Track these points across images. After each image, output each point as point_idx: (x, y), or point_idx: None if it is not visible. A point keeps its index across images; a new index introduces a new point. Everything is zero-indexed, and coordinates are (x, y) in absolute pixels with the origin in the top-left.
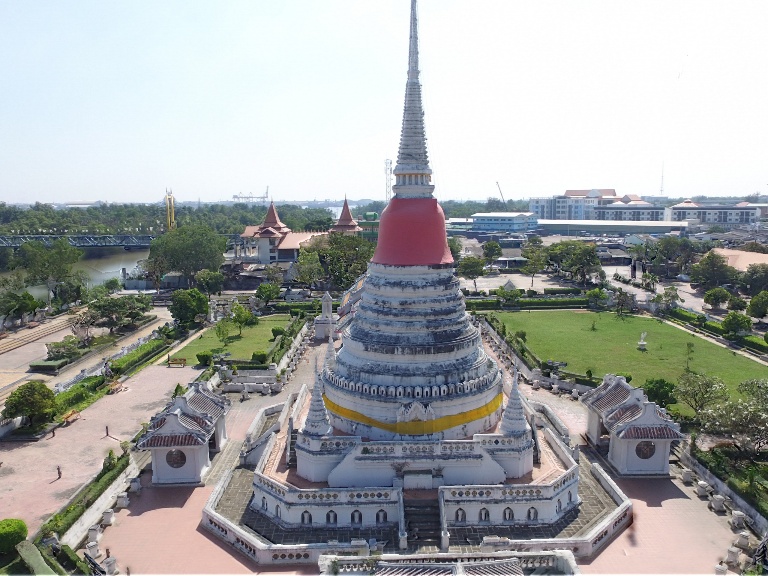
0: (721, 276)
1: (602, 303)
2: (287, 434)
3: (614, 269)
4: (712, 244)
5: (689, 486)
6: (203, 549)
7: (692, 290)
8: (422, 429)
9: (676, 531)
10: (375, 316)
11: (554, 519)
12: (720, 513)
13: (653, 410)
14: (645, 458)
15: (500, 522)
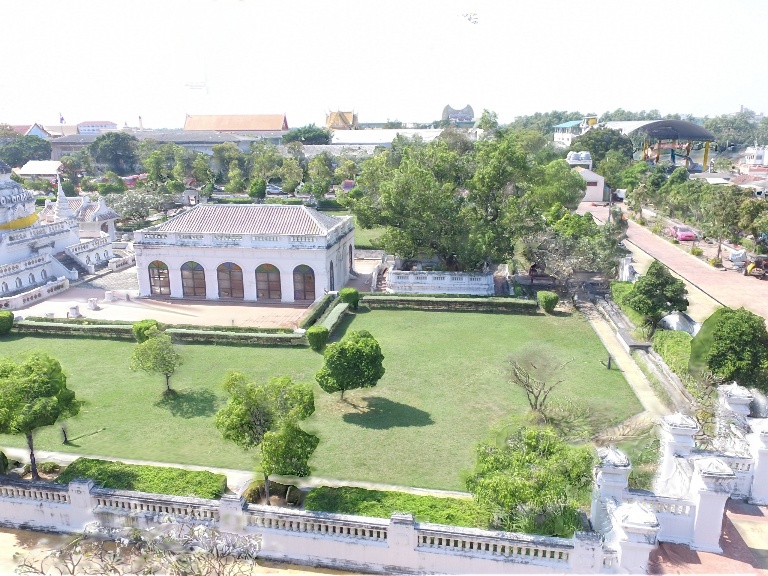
0: None
1: None
2: None
3: None
4: None
5: (131, 241)
6: None
7: None
8: (25, 223)
9: None
10: None
11: (114, 255)
12: None
13: (104, 203)
14: None
15: (96, 262)
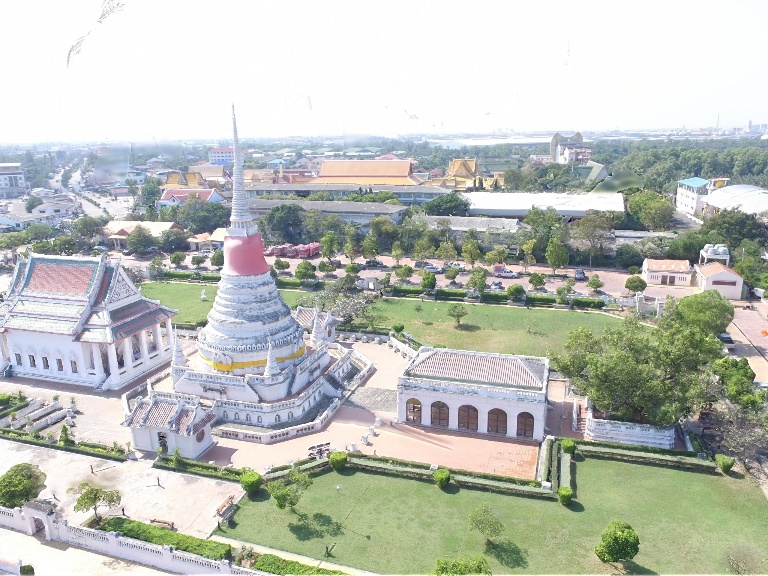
0: (152, 243)
1: None
2: (244, 388)
3: (17, 251)
4: (106, 218)
5: None
6: (292, 443)
7: (128, 257)
8: None
9: (372, 352)
10: (258, 305)
11: None
12: (368, 342)
13: None
14: (330, 337)
15: (343, 375)
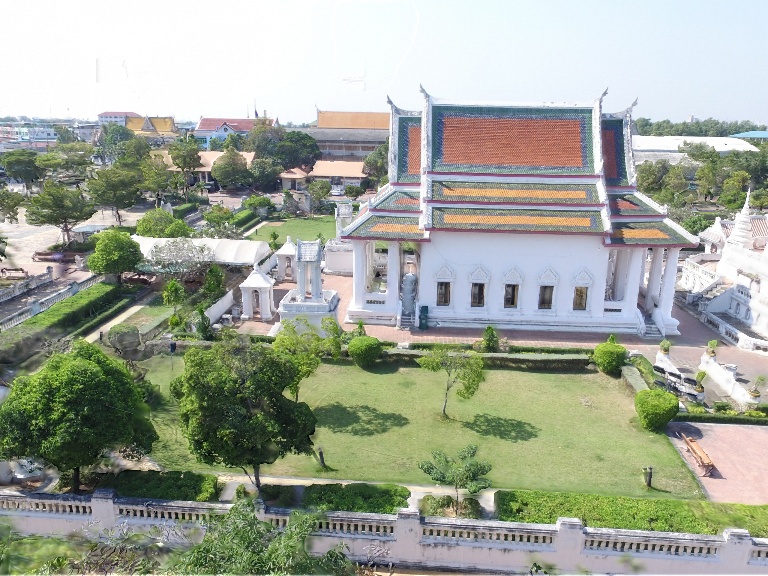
0: None
1: (256, 213)
2: None
3: None
4: None
5: None
6: None
7: (214, 194)
8: None
9: None
10: None
11: None
12: None
13: None
14: None
15: None
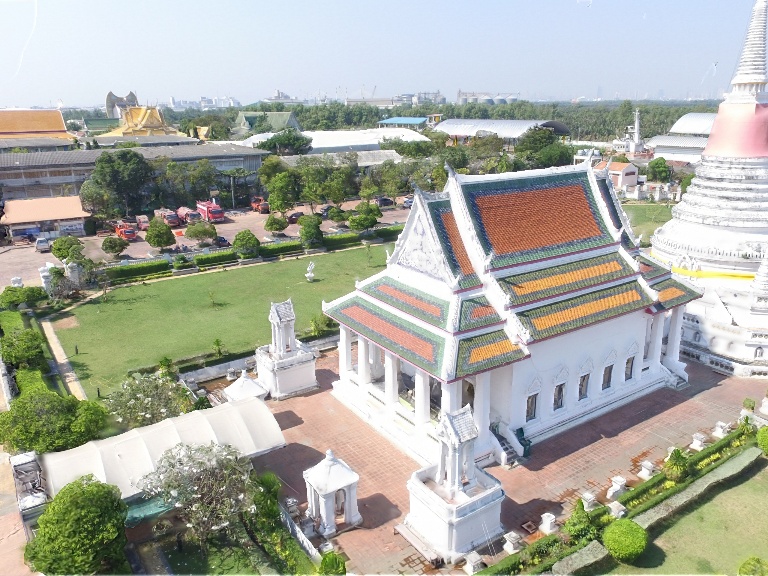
0: None
1: None
2: None
3: None
4: None
5: None
6: None
7: None
8: None
9: None
10: None
11: None
12: None
13: None
14: None
15: None
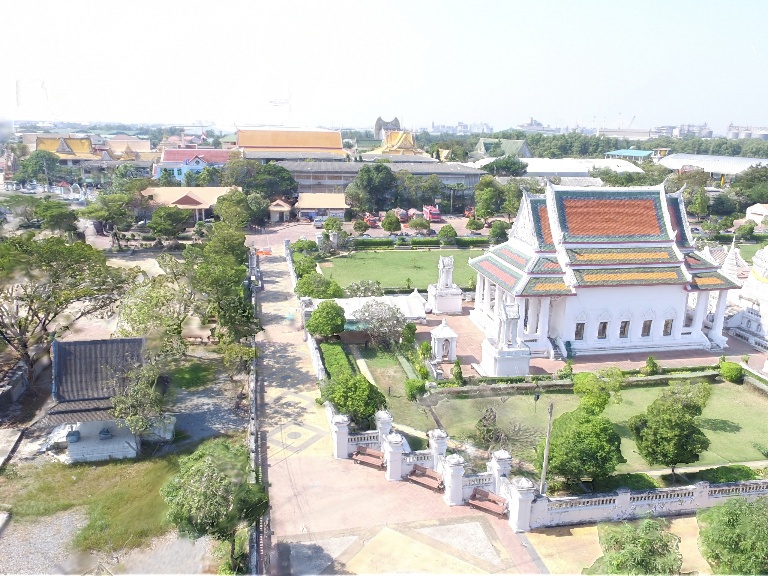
0: None
1: None
2: None
3: None
4: None
5: None
6: None
7: None
8: None
9: None
10: None
11: None
12: None
13: None
14: None
15: None
